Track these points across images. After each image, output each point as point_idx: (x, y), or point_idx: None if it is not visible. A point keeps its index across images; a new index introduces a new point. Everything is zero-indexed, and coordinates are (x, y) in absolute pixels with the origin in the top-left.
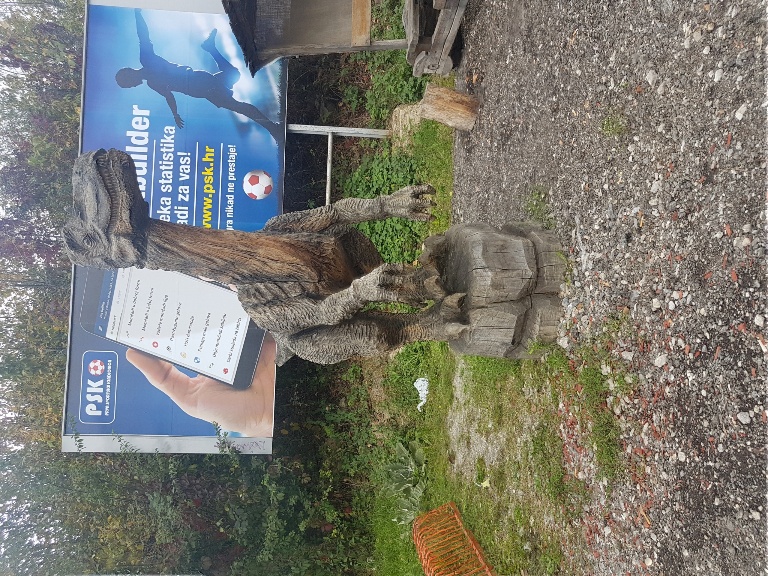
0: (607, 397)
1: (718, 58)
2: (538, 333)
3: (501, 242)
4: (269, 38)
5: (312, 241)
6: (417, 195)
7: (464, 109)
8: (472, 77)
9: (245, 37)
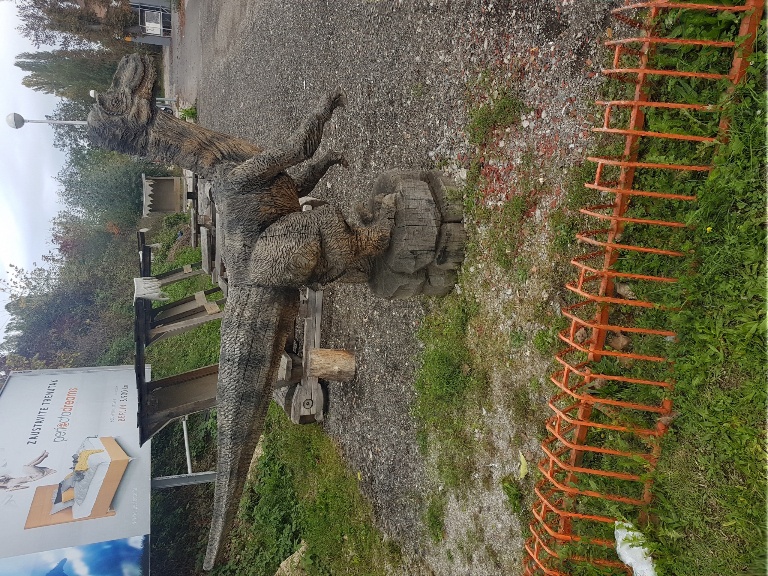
0: None
1: None
2: (446, 190)
3: None
4: (161, 401)
5: None
6: None
7: (343, 353)
8: None
9: (141, 393)
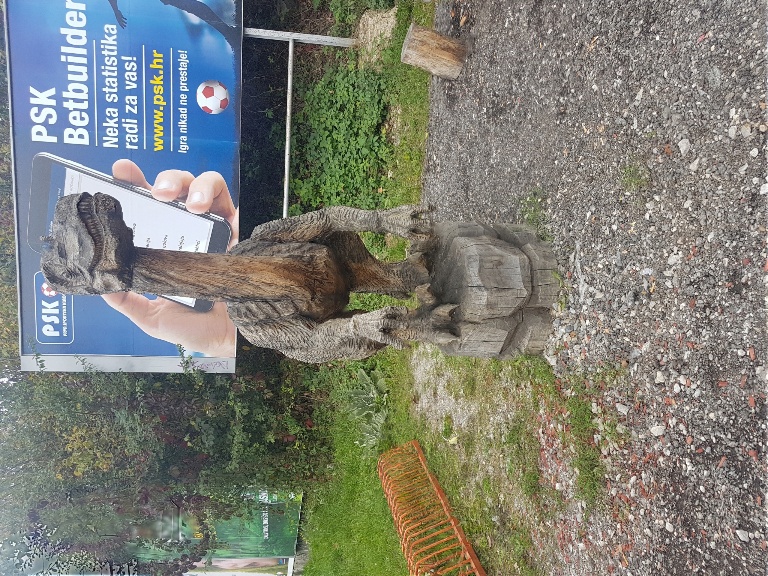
0: (595, 433)
1: (767, 170)
2: (526, 346)
3: (497, 257)
4: None
5: (304, 255)
6: (417, 213)
7: (450, 58)
8: (459, 15)
9: None
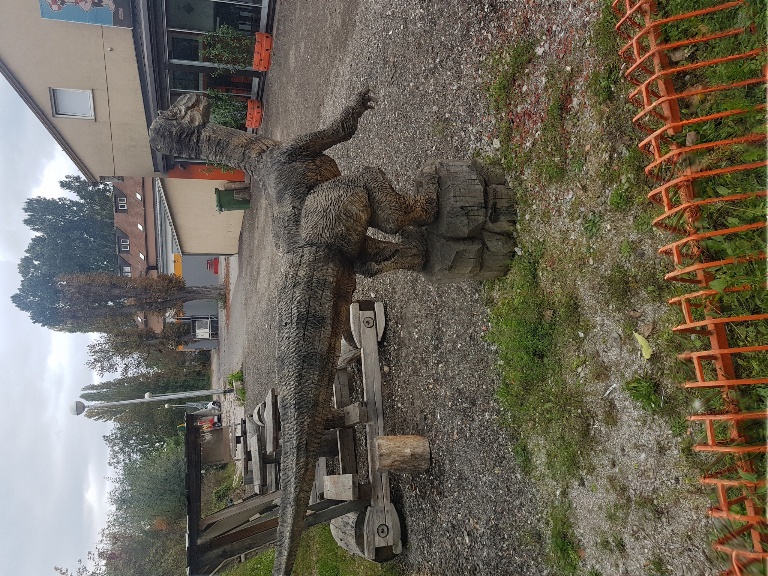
0: None
1: None
2: None
3: None
4: (213, 540)
5: None
6: None
7: (413, 435)
8: None
9: None
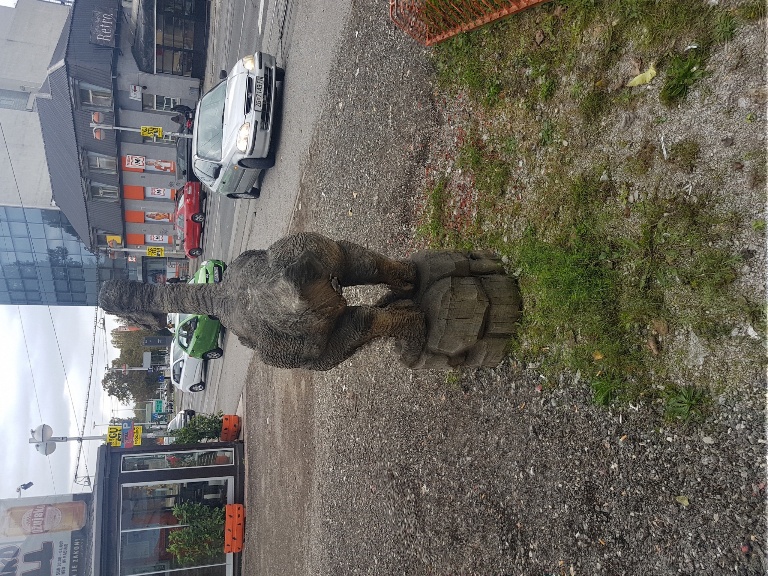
0: None
1: None
2: None
3: None
4: None
5: None
6: None
7: None
8: None
9: None
